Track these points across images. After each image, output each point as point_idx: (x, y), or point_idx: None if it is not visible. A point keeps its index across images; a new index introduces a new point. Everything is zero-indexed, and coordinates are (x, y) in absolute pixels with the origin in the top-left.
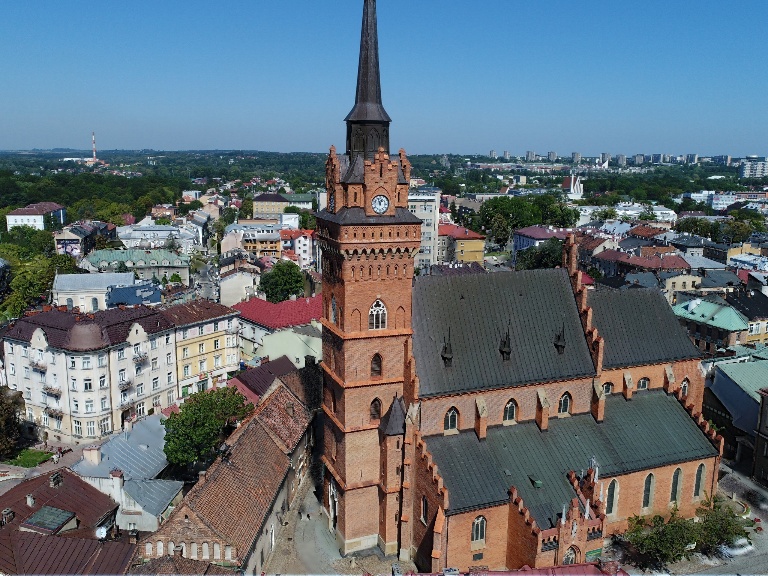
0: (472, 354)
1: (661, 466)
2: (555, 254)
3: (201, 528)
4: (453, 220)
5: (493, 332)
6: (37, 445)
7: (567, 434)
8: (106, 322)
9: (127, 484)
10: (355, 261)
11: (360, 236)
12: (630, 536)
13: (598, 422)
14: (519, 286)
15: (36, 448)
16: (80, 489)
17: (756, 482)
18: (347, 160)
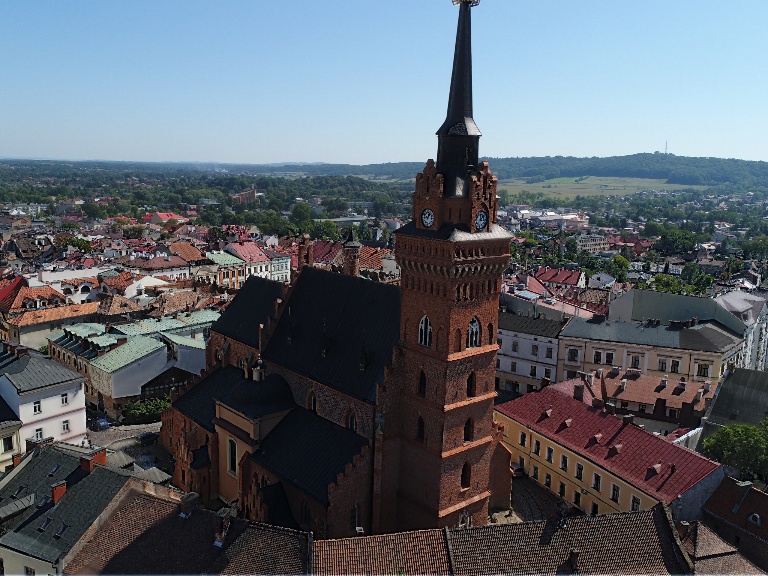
0: None
1: None
2: None
3: None
4: None
5: None
6: None
7: None
8: None
9: None
10: None
11: None
12: None
13: None
14: None
15: None
16: None
17: None
18: None
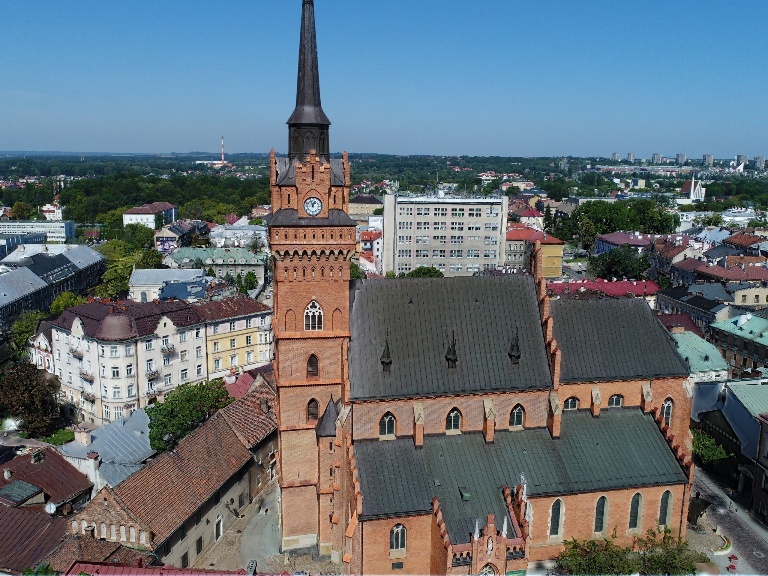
0: (414, 360)
1: (615, 489)
2: (625, 261)
3: (118, 511)
4: (544, 224)
5: (441, 338)
6: (73, 425)
7: (515, 448)
8: (137, 314)
9: (104, 466)
10: (288, 262)
11: (291, 237)
12: (563, 560)
13: (553, 438)
14: (476, 292)
15: (71, 428)
16: (60, 467)
17: (754, 516)
18: (287, 162)
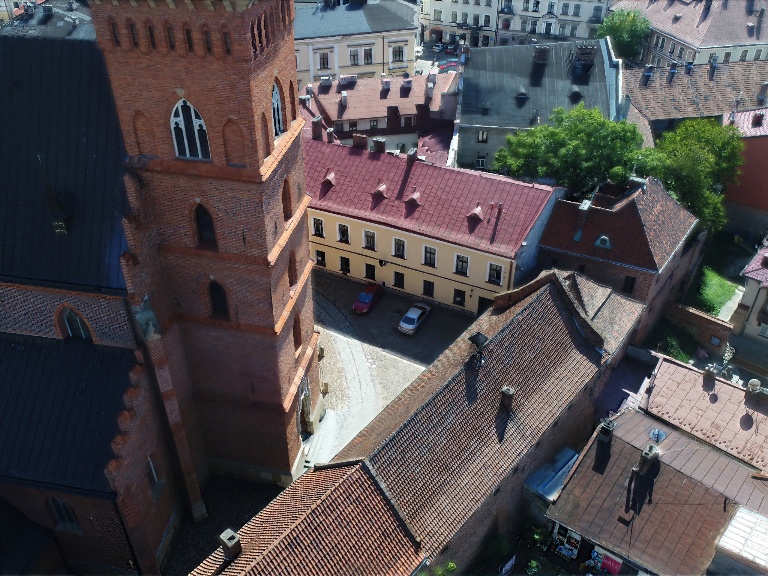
0: None
1: None
2: None
3: None
4: None
5: None
6: None
7: None
8: None
9: None
10: None
11: None
12: None
13: None
14: None
15: None
16: None
17: None
18: None
